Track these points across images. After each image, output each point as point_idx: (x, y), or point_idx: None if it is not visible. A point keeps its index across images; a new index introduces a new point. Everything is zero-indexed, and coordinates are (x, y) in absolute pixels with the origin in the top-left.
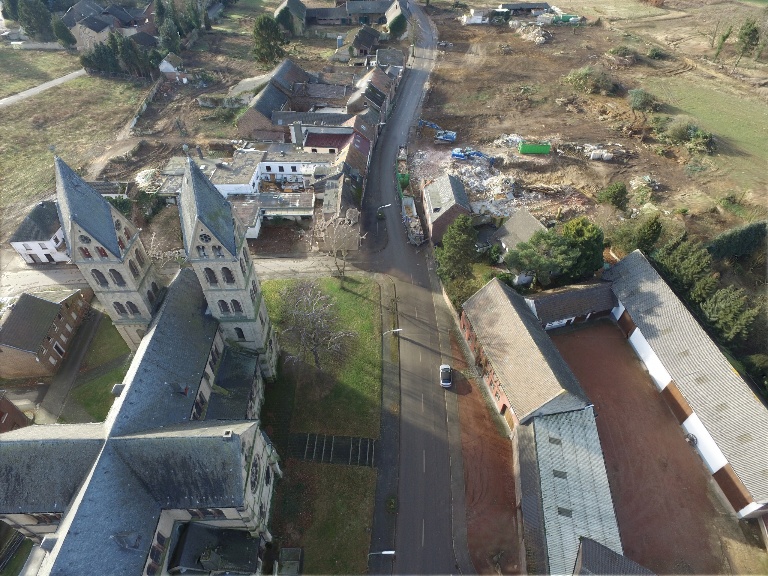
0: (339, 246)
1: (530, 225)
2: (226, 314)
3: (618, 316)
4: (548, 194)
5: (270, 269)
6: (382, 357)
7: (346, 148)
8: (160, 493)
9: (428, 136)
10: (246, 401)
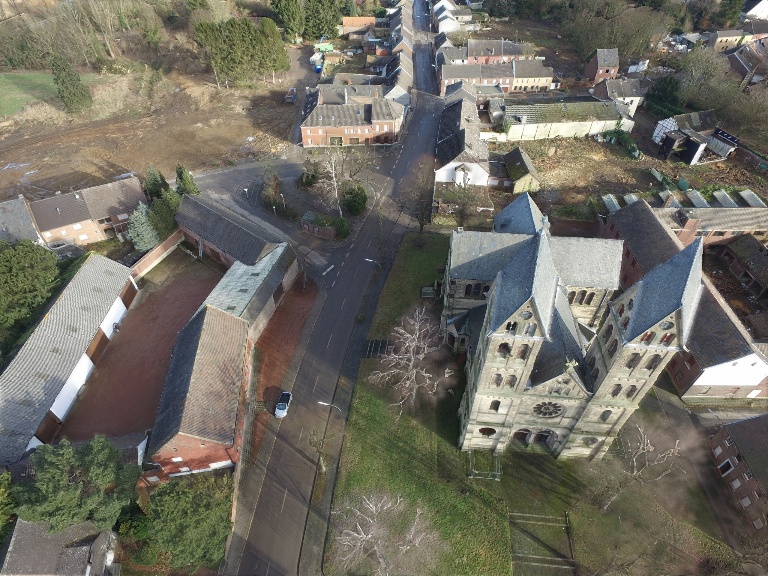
0: None
1: None
2: None
3: None
4: None
5: None
6: (344, 437)
7: None
8: None
9: None
10: (473, 342)
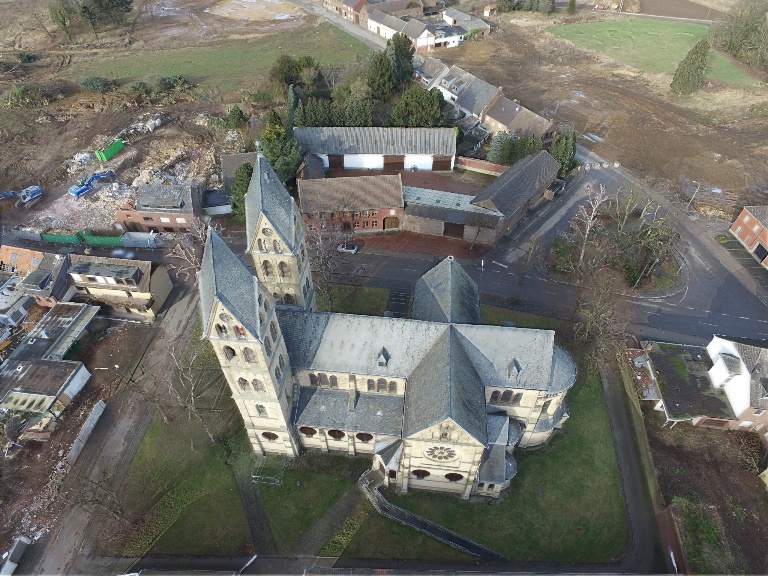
0: (163, 296)
1: (242, 160)
2: (306, 300)
3: (327, 164)
4: (183, 160)
5: (161, 360)
6: None
7: (6, 252)
8: (474, 321)
9: (6, 211)
10: None
